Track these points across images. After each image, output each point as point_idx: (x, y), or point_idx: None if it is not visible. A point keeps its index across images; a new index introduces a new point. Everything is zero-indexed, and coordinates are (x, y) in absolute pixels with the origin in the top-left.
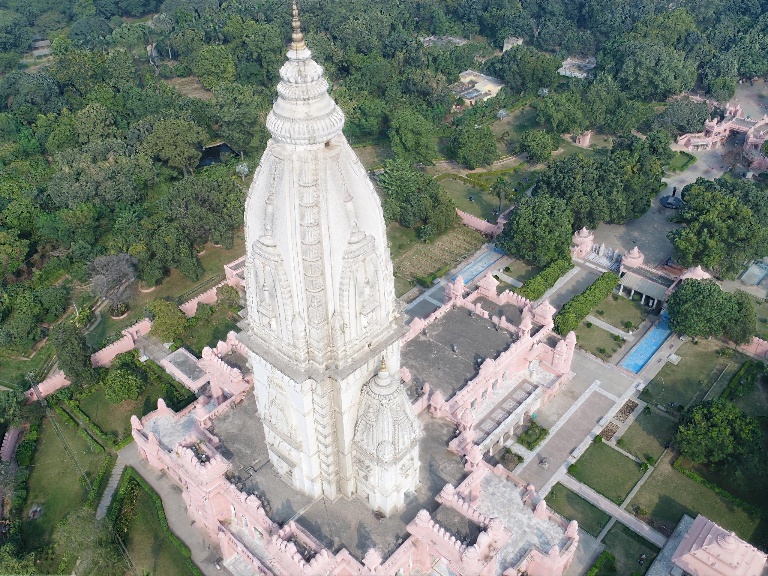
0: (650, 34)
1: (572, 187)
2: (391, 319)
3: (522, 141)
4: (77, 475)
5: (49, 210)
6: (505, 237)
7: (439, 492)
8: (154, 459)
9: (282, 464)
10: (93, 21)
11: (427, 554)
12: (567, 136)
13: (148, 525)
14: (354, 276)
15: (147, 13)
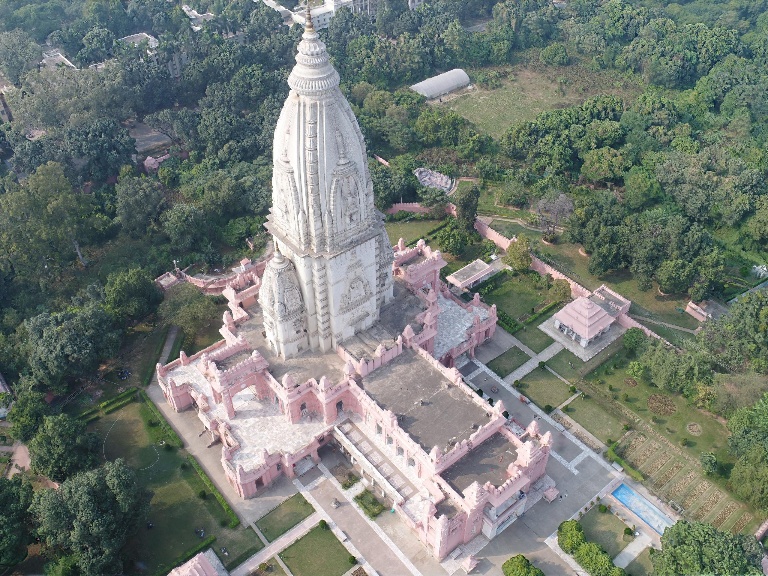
0: None
1: None
2: (303, 241)
3: None
4: None
5: None
6: None
7: None
8: None
9: None
10: None
11: None
12: None
13: None
14: None
15: None
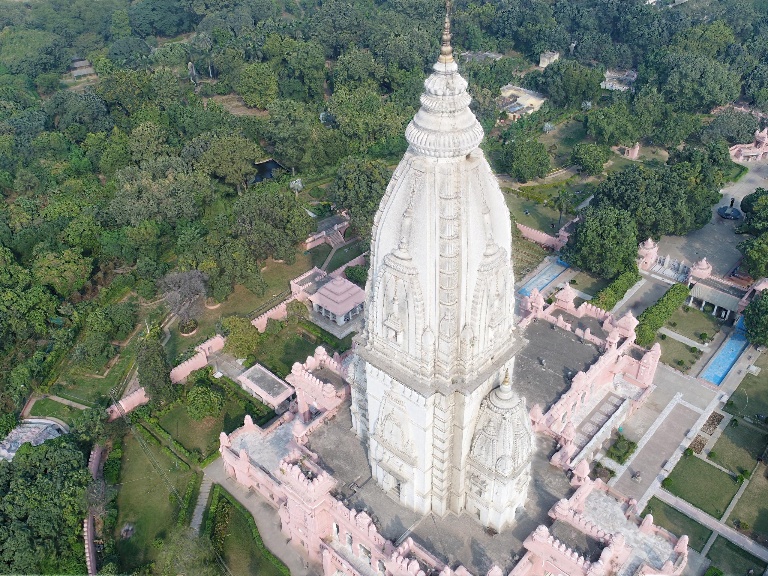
0: (690, 46)
1: (635, 199)
2: (510, 332)
3: (573, 154)
4: (165, 493)
5: (108, 228)
6: (570, 249)
7: (549, 507)
8: (244, 476)
9: (389, 480)
10: (132, 41)
11: (541, 571)
12: (615, 148)
13: (243, 543)
14: (488, 289)
15: (180, 33)
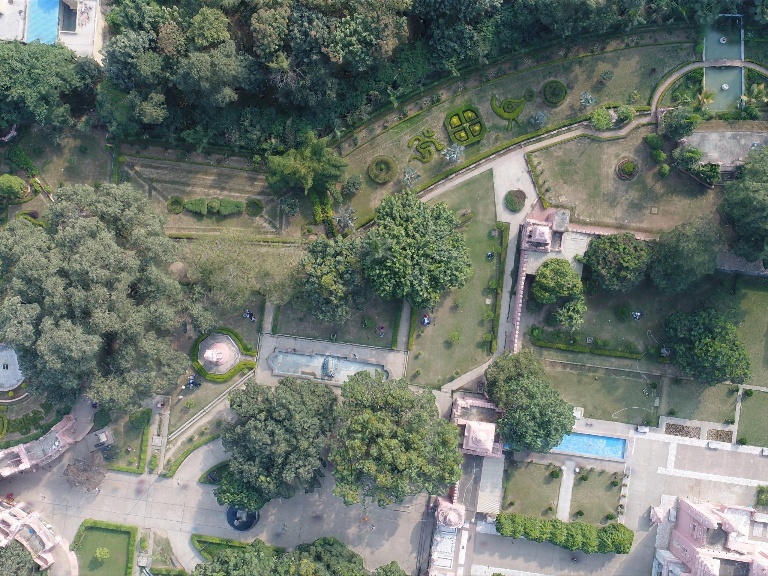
0: None
1: None
2: None
3: None
4: None
5: None
6: None
7: None
8: None
9: None
10: None
11: None
12: None
13: None
14: None
15: None
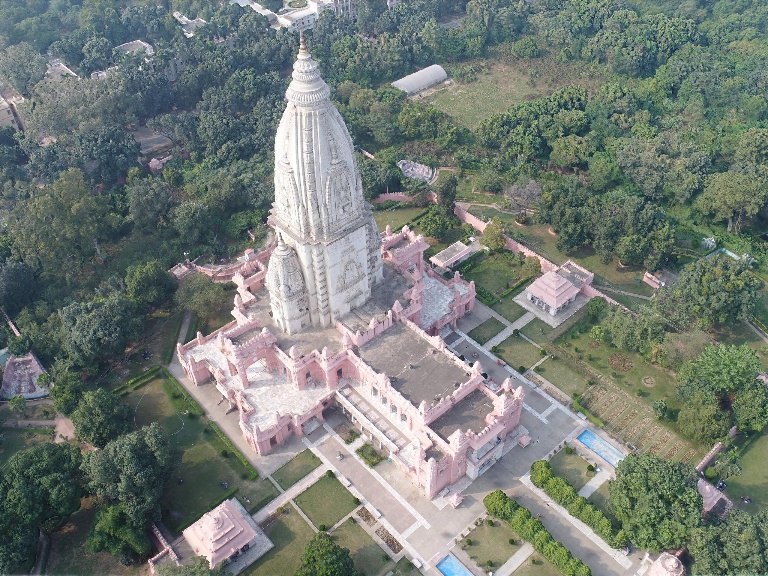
0: None
1: None
2: (304, 231)
3: None
4: None
5: None
6: None
7: None
8: None
9: None
10: None
11: None
12: None
13: None
14: None
15: None
